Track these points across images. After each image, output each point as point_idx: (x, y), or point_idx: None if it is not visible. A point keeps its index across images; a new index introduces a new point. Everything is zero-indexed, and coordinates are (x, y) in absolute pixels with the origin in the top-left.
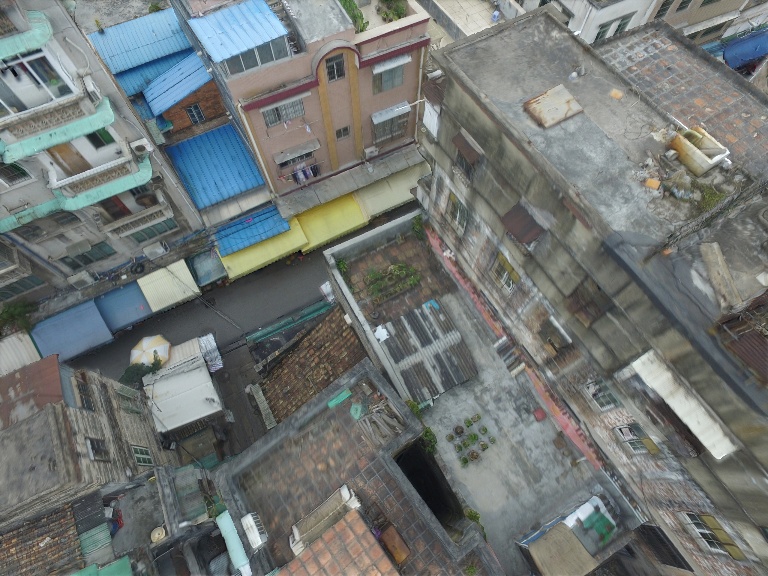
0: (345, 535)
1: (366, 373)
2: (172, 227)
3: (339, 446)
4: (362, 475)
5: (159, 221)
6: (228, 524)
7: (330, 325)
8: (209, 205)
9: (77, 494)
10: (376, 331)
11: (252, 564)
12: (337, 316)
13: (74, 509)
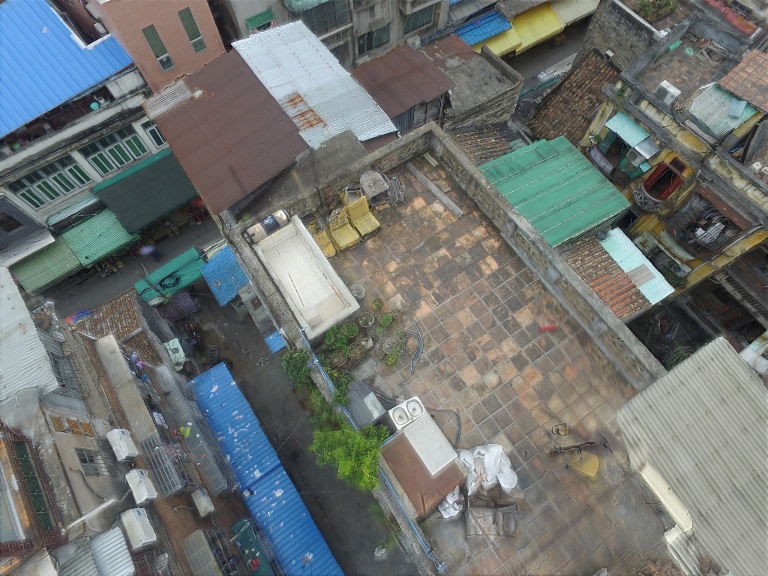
0: (758, 60)
1: (693, 25)
2: (427, 22)
3: (687, 69)
4: (710, 82)
5: (438, 0)
6: (617, 124)
7: (587, 68)
8: (456, 2)
9: (502, 116)
10: (661, 33)
11: (673, 111)
12: (593, 60)
13: (497, 130)
